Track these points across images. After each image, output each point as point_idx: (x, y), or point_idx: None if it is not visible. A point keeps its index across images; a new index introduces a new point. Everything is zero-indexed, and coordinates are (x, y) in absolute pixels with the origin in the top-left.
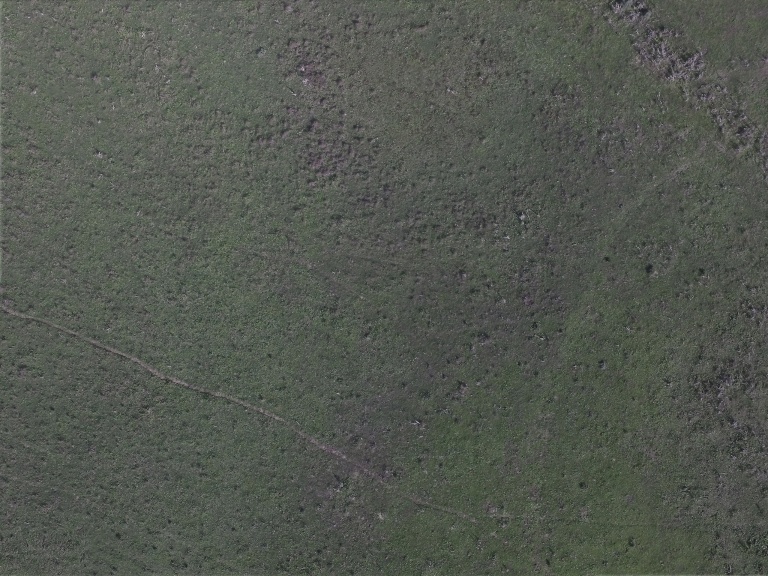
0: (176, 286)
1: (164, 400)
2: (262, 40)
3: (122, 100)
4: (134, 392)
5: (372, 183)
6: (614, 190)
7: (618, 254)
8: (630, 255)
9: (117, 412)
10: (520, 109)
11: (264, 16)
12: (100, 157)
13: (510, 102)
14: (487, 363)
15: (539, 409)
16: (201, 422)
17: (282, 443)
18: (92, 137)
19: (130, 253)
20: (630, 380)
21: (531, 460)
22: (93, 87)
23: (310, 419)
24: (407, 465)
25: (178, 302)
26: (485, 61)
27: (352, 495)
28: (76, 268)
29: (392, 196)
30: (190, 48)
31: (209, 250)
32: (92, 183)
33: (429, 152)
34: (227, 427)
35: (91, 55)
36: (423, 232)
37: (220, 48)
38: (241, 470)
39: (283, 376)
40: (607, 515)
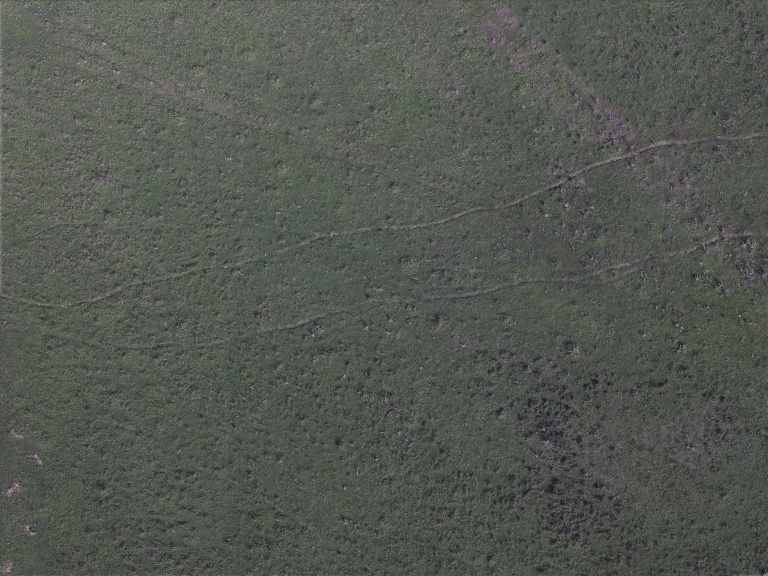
0: None
1: None
2: (502, 401)
3: (366, 466)
4: None
5: (614, 541)
6: None
7: None
8: None
9: None
10: (760, 465)
11: (503, 377)
12: (346, 524)
13: (750, 458)
14: None
15: None
16: None
17: None
18: (337, 503)
19: None
20: None
21: None
22: (337, 453)
23: None
24: None
25: None
26: (724, 417)
27: None
28: None
29: (635, 555)
30: (431, 411)
31: None
32: (338, 549)
33: (670, 509)
34: None
35: (334, 421)
36: None
37: (461, 410)
38: None
39: None
40: None
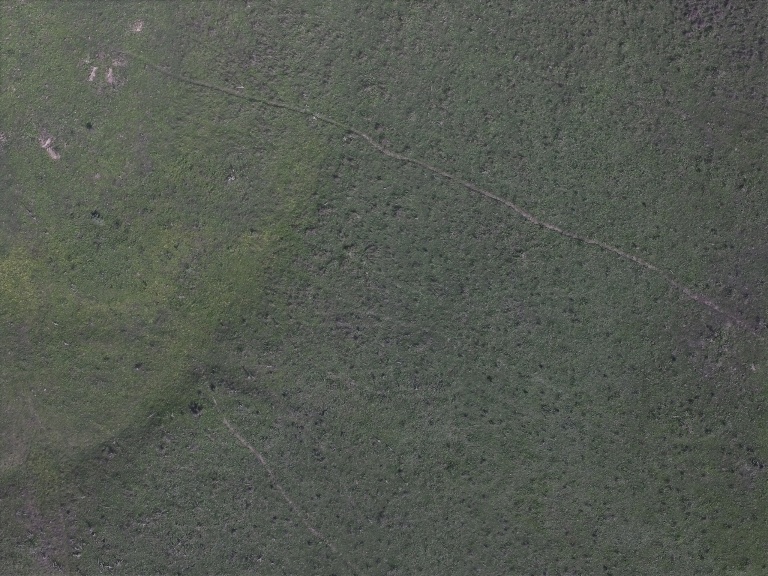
0: (552, 132)
1: (538, 245)
2: None
3: None
4: (508, 236)
5: (747, 36)
6: None
7: None
8: None
9: (491, 255)
10: None
11: None
12: (479, 1)
13: None
14: None
15: None
16: (574, 268)
17: (655, 291)
18: None
19: (506, 98)
20: None
21: None
22: None
23: (683, 269)
24: None
25: (554, 147)
26: None
27: (724, 346)
28: (452, 111)
29: (767, 49)
30: None
31: (585, 97)
32: (470, 27)
33: None
34: (600, 274)
35: None
36: None
37: None
38: (613, 317)
39: (657, 225)
40: None
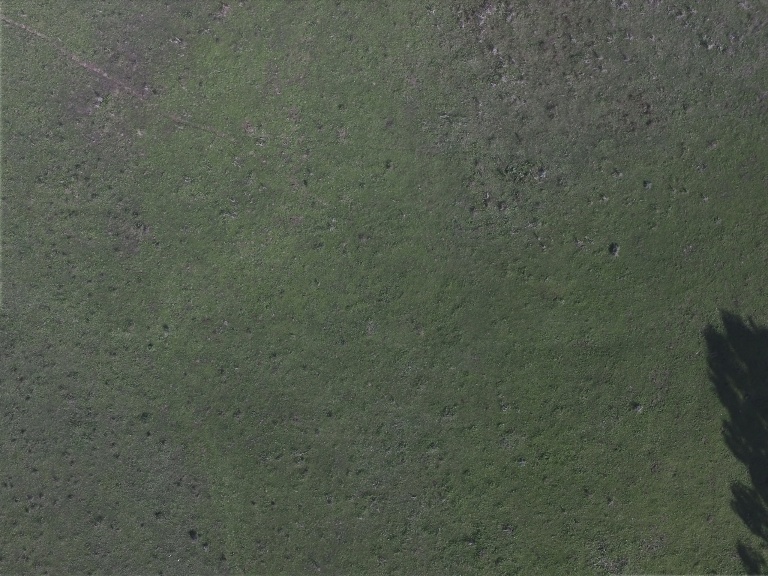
0: None
1: None
2: None
3: None
4: None
5: None
6: None
7: None
8: None
9: None
10: None
11: None
12: None
13: None
14: None
15: (301, 32)
16: None
17: (43, 58)
18: None
19: None
20: (392, 6)
21: (292, 82)
22: None
23: (72, 36)
24: (167, 83)
25: None
26: None
27: (112, 111)
28: None
29: None
30: None
31: None
32: None
33: None
34: None
35: None
36: None
37: None
38: (1, 84)
39: None
40: (365, 137)
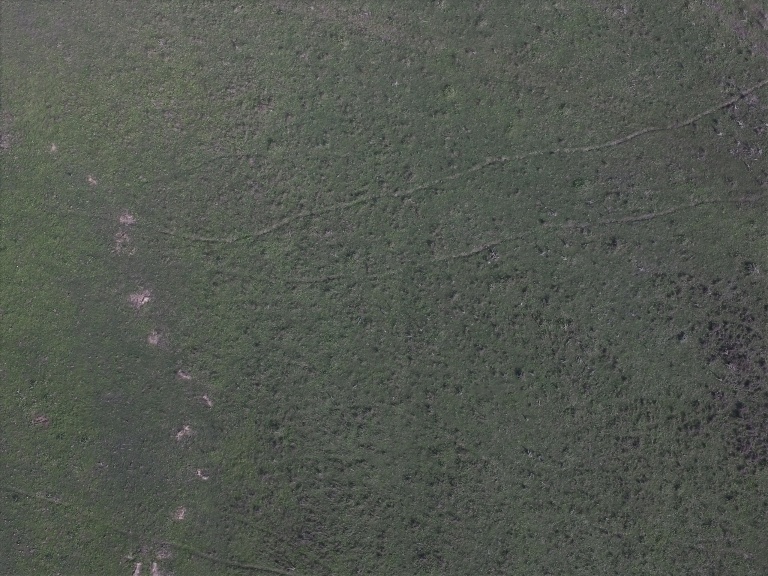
0: None
1: None
2: (683, 325)
3: (548, 396)
4: None
5: None
6: None
7: None
8: None
9: None
10: None
11: (683, 300)
12: (530, 456)
13: None
14: None
15: None
16: None
17: None
18: (519, 435)
19: (565, 554)
20: None
21: None
22: (518, 384)
23: None
24: None
25: None
26: None
27: None
28: (511, 572)
29: None
30: (611, 337)
31: (645, 546)
32: (522, 483)
33: None
34: None
35: (513, 350)
36: None
37: (641, 335)
38: None
39: None
40: None
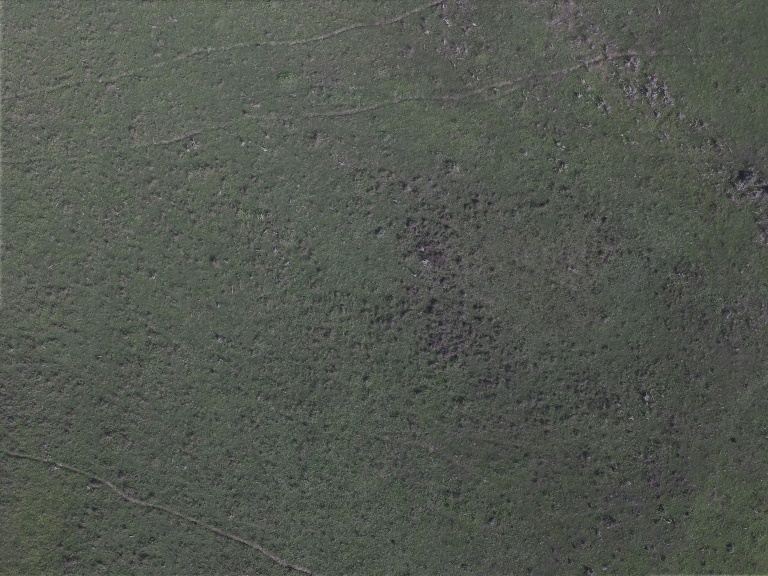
0: (298, 472)
1: None
2: (381, 220)
3: (241, 284)
4: None
5: (493, 363)
6: (739, 369)
7: (744, 435)
8: (756, 436)
9: None
10: (642, 287)
11: (382, 196)
12: (220, 342)
13: (632, 280)
14: (613, 547)
15: None
16: None
17: None
18: (211, 321)
19: (251, 439)
20: (759, 564)
21: None
22: (212, 271)
23: None
24: None
25: (300, 488)
26: (606, 239)
27: None
28: (196, 454)
29: (514, 377)
30: (308, 229)
31: (330, 435)
32: (212, 368)
33: (550, 331)
34: None
35: (209, 238)
36: (545, 413)
37: (338, 229)
38: None
39: (407, 562)
40: None
